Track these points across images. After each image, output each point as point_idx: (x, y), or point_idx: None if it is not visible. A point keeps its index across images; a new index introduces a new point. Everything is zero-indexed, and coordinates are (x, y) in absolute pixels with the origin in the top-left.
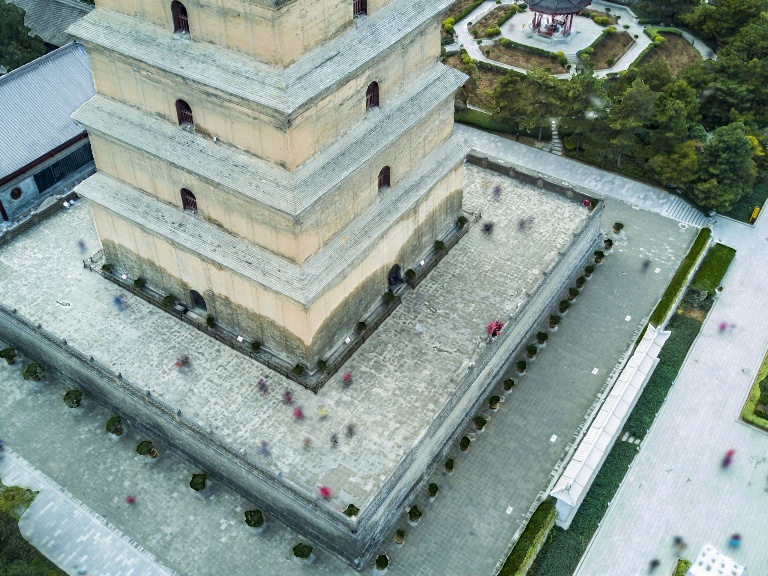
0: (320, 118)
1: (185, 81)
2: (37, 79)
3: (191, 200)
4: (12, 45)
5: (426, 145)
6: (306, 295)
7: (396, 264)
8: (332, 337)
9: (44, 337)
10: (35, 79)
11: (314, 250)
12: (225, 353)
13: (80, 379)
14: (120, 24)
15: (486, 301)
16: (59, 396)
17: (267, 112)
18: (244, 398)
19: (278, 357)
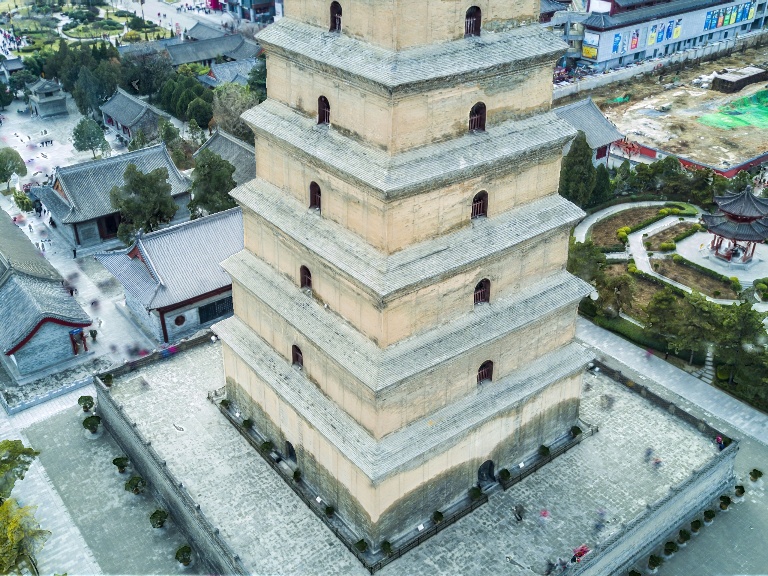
0: (420, 304)
1: (308, 251)
2: (225, 226)
3: (300, 357)
4: (216, 194)
5: (539, 347)
6: (376, 471)
7: (490, 460)
8: (403, 520)
9: (151, 455)
10: (223, 226)
11: (395, 428)
12: (301, 510)
13: (170, 502)
14: (271, 194)
15: (578, 521)
16: (149, 513)
17: (367, 290)
18: (303, 560)
19: (348, 527)
